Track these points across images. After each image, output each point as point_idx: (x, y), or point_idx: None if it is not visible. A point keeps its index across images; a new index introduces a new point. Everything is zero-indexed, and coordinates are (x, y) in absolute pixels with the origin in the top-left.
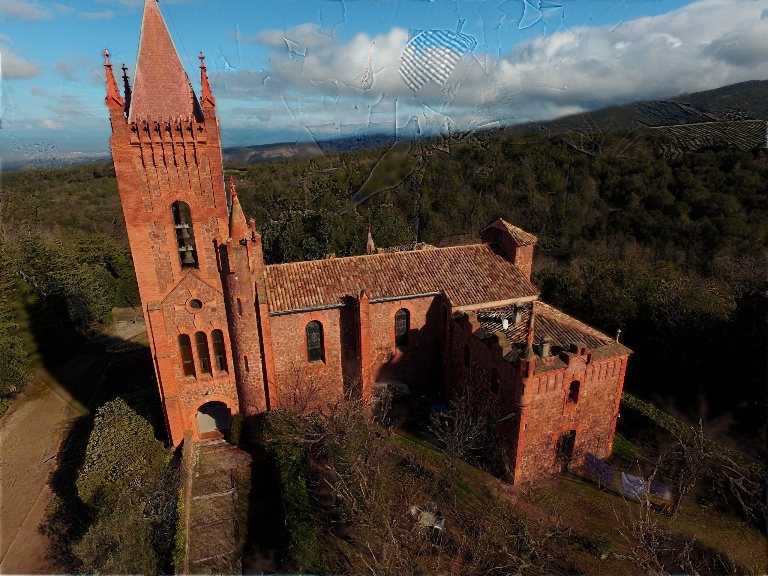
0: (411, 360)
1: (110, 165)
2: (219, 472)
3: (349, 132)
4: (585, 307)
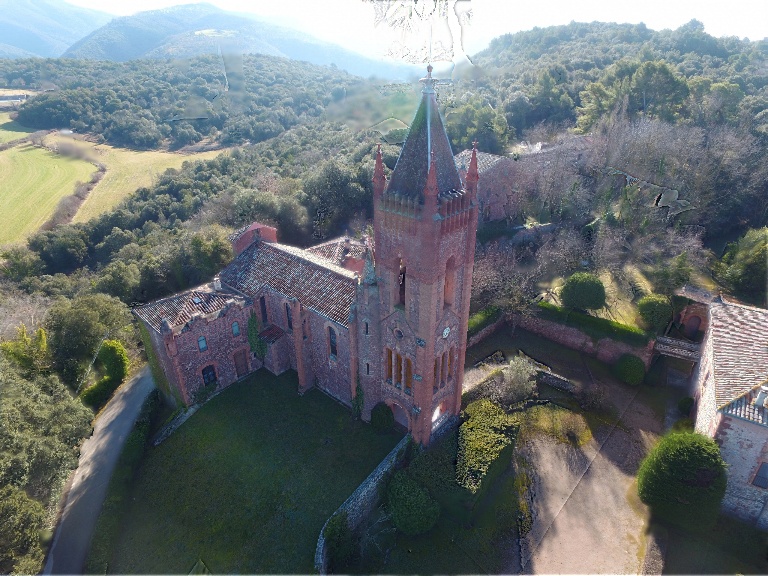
0: None
1: None
2: None
3: None
4: None
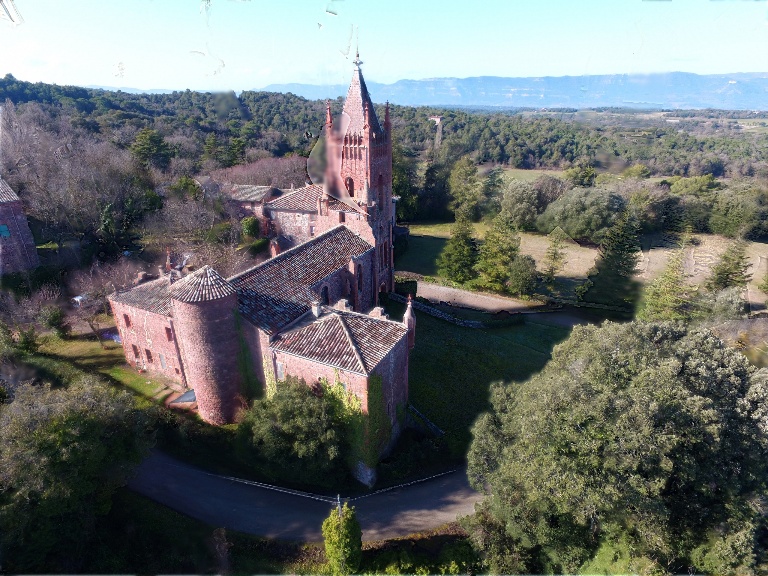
0: None
1: None
2: None
3: None
4: None
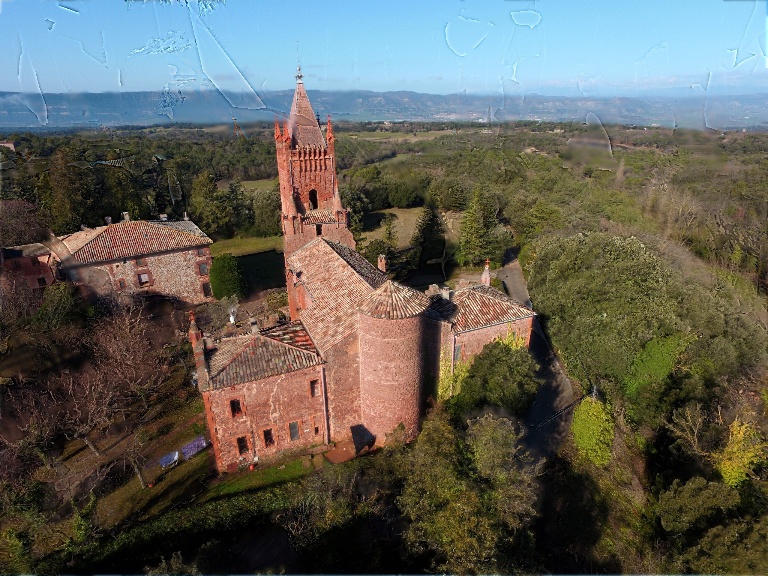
0: None
1: None
2: None
3: None
4: None
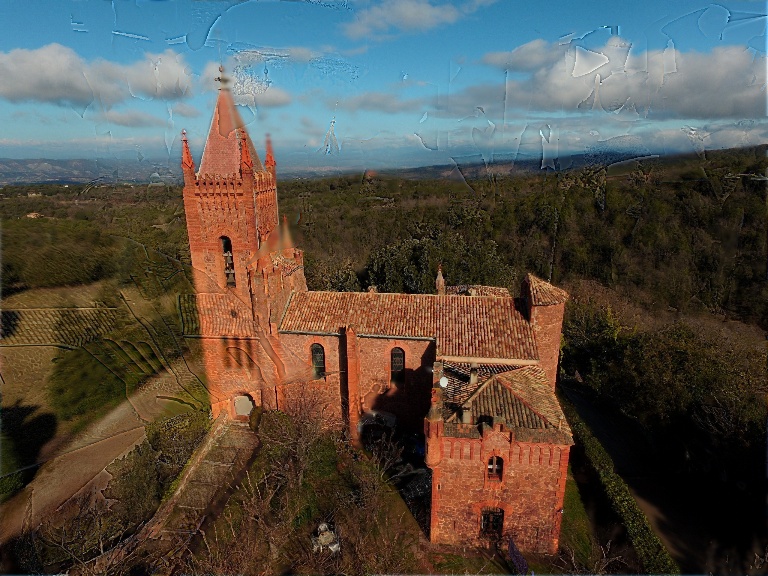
0: (406, 397)
1: (292, 188)
2: (231, 448)
3: (506, 161)
4: (633, 385)
